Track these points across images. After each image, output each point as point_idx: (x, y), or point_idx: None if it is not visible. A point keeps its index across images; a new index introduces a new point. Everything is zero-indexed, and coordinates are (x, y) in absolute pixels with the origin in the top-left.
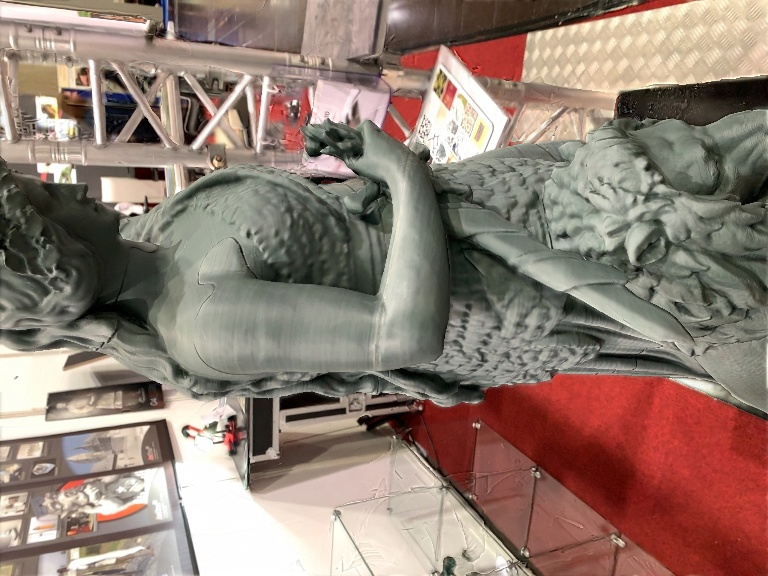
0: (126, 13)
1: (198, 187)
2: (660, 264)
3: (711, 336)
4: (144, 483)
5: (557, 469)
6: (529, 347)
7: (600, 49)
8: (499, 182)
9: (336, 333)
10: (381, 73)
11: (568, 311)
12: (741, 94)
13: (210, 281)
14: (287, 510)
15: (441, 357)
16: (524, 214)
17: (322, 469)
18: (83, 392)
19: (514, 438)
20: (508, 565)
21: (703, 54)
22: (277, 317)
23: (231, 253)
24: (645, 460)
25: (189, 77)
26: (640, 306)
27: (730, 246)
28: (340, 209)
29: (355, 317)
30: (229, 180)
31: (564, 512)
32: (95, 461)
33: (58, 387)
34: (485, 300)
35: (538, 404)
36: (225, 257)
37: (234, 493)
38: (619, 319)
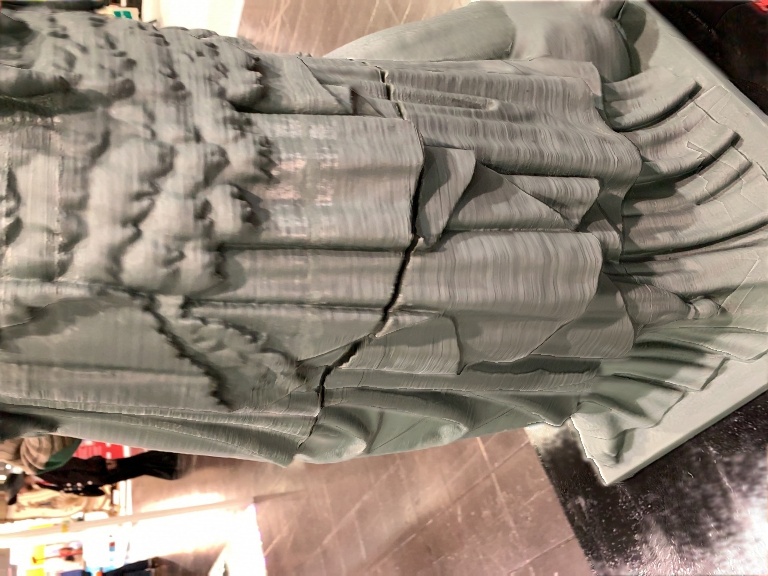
0: None
1: None
2: None
3: None
4: None
5: None
6: None
7: None
8: None
9: None
10: None
11: None
12: (538, 429)
13: None
14: None
15: None
16: None
17: None
18: None
19: None
20: None
21: None
22: None
23: None
24: None
25: None
26: None
27: None
28: None
29: None
30: None
31: None
32: None
33: None
34: None
35: None
36: None
37: None
38: None
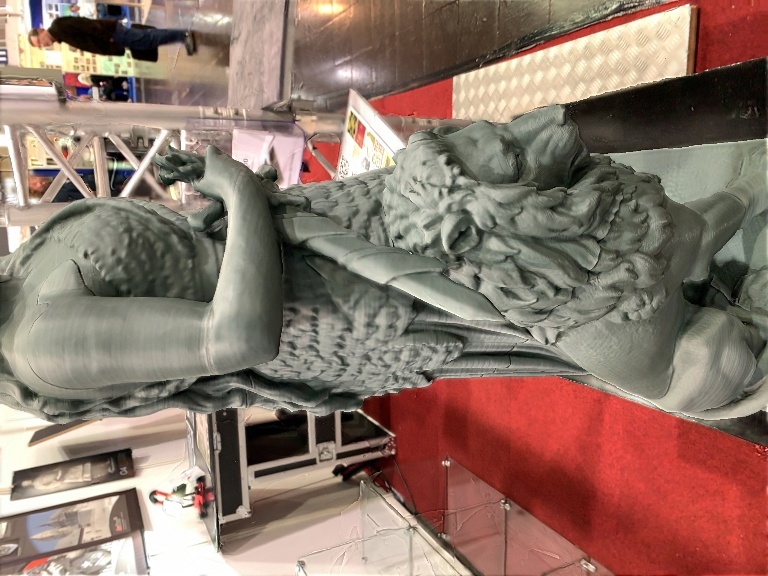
0: (26, 77)
1: (54, 220)
2: (477, 252)
3: (550, 320)
4: (111, 555)
5: (524, 498)
6: (387, 348)
7: (517, 85)
8: (343, 194)
9: (165, 339)
10: (295, 119)
11: (419, 309)
12: (607, 107)
13: (46, 301)
14: (260, 570)
15: (300, 364)
16: (366, 221)
17: (297, 524)
18: (50, 467)
19: (482, 472)
20: None
21: (604, 81)
22: (107, 328)
23: (69, 274)
24: (603, 478)
25: (113, 137)
26: (453, 290)
27: (534, 228)
28: (188, 229)
29: (184, 323)
30: (81, 210)
31: (538, 543)
32: (60, 537)
33: (24, 464)
34: (331, 303)
35: (500, 434)
36: (63, 278)
37: (205, 557)
38: (434, 303)
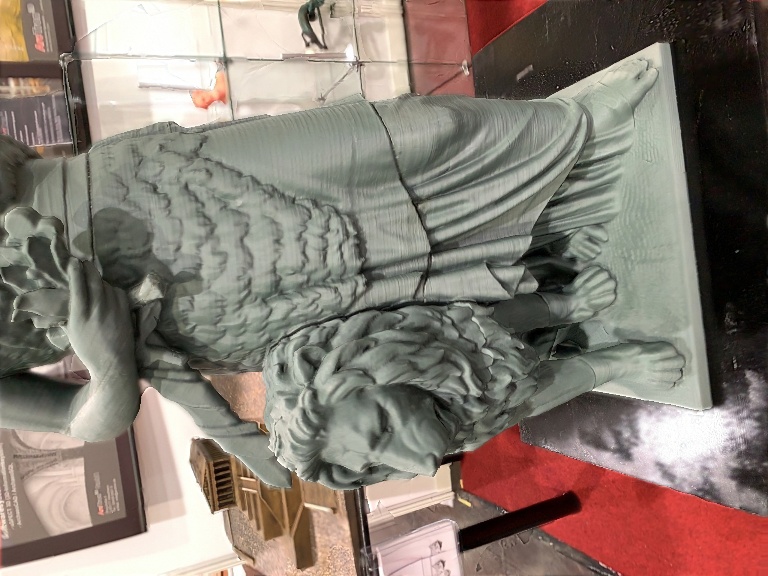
0: None
1: None
2: None
3: None
4: None
5: None
6: None
7: None
8: (236, 325)
9: None
10: None
11: None
12: (741, 109)
13: None
14: None
15: None
16: None
17: None
18: None
19: None
20: (353, 60)
21: None
22: None
23: None
24: None
25: None
26: (267, 472)
27: None
28: None
29: (44, 429)
30: None
31: None
32: None
33: None
34: None
35: None
36: None
37: None
38: None
